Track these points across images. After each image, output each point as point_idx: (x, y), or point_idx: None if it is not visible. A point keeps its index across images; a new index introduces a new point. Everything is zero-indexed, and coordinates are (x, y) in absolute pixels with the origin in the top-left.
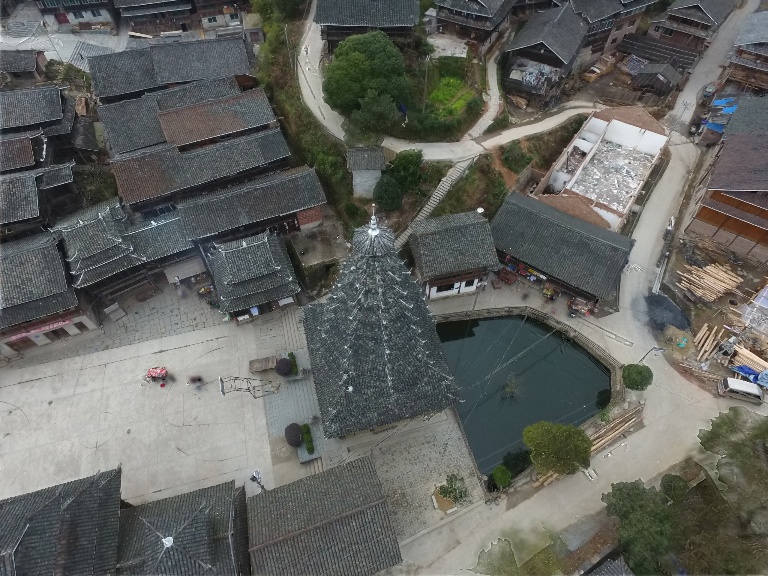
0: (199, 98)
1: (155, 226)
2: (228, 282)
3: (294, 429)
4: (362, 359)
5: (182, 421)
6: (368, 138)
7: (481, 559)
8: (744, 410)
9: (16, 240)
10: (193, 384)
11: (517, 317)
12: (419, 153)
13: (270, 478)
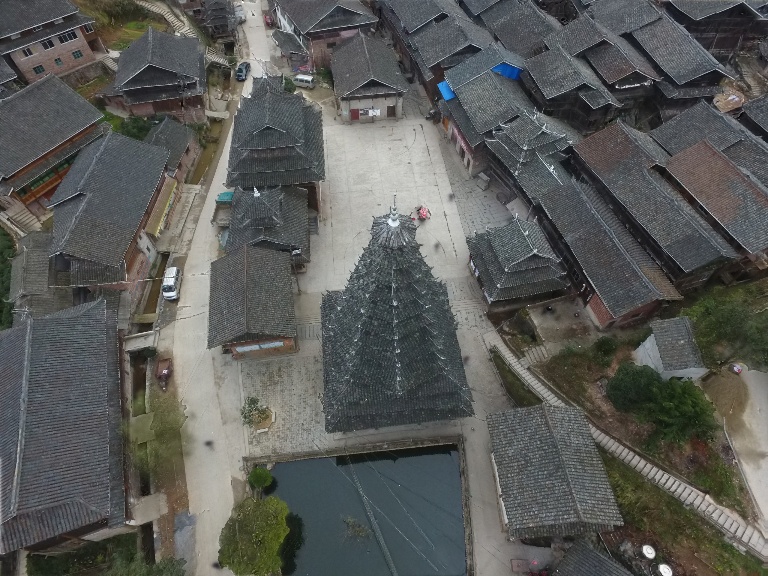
0: (766, 177)
1: (551, 171)
2: (488, 231)
3: None
4: None
5: None
6: (707, 335)
7: None
8: None
9: (530, 100)
10: None
11: None
12: (710, 421)
13: (322, 289)
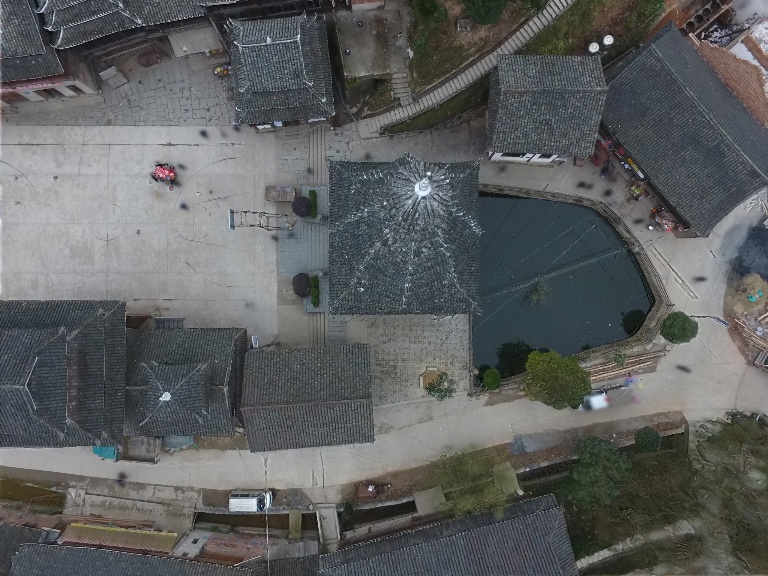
0: None
1: None
2: (244, 90)
3: (302, 282)
4: (379, 277)
5: (192, 235)
6: None
7: (442, 462)
8: (764, 433)
9: None
10: (204, 196)
11: (585, 206)
12: None
13: (274, 316)
